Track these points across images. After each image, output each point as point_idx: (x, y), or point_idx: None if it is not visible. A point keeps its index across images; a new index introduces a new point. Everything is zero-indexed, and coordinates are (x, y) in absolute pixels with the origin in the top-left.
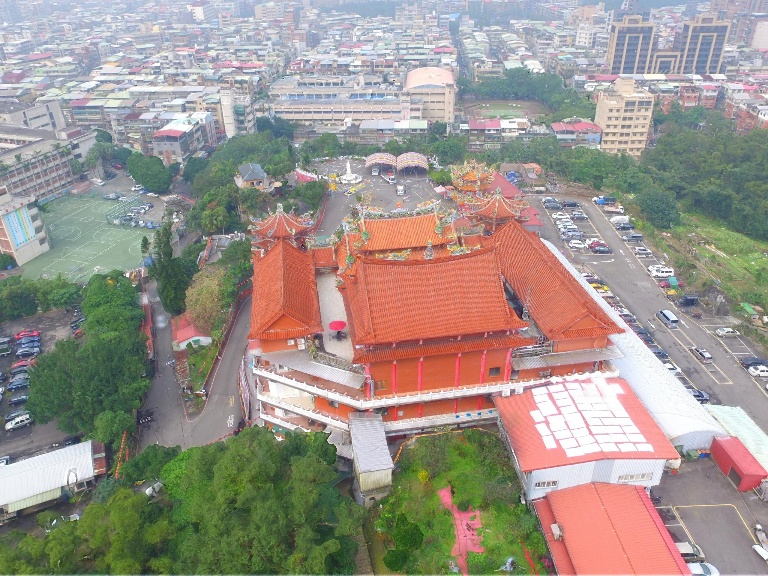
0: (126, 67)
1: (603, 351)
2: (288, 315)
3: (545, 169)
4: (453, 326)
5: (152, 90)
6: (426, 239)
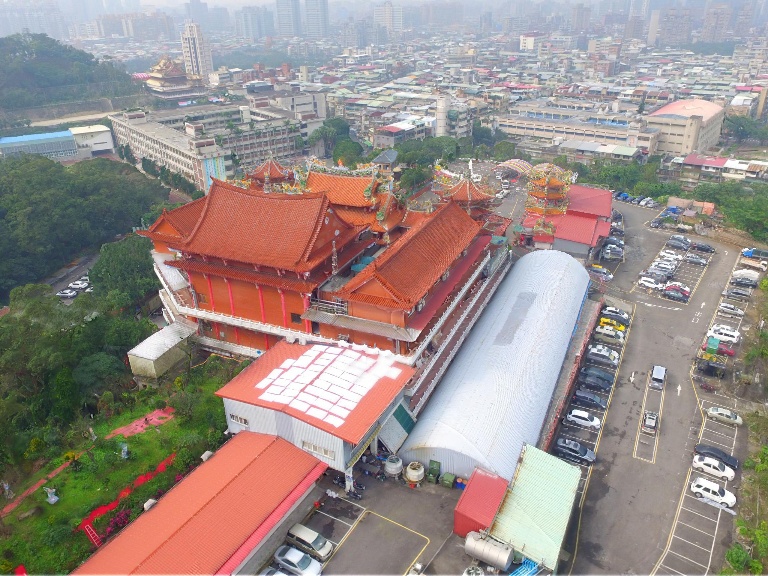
0: (417, 79)
1: (399, 330)
2: (167, 220)
3: (722, 211)
4: (251, 255)
5: (412, 96)
6: (353, 199)
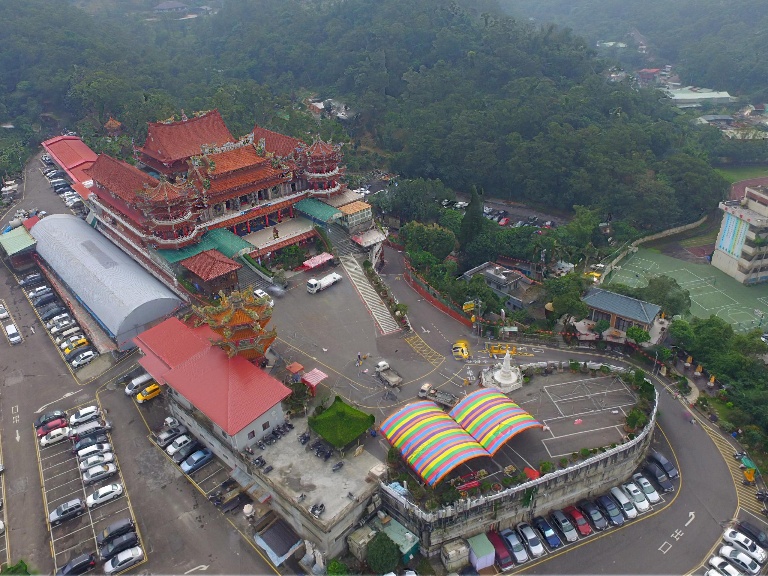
0: None
1: None
2: None
3: None
4: None
5: None
6: None
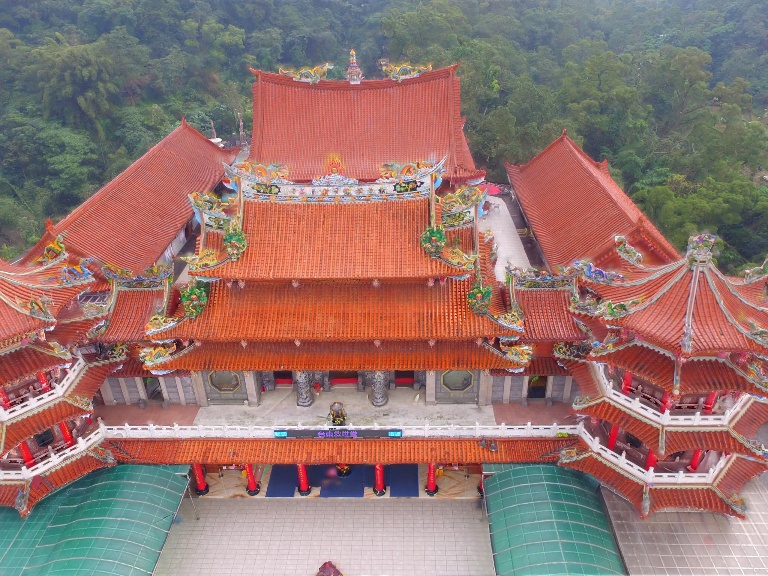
0: None
1: None
2: None
3: None
4: None
5: None
6: None
